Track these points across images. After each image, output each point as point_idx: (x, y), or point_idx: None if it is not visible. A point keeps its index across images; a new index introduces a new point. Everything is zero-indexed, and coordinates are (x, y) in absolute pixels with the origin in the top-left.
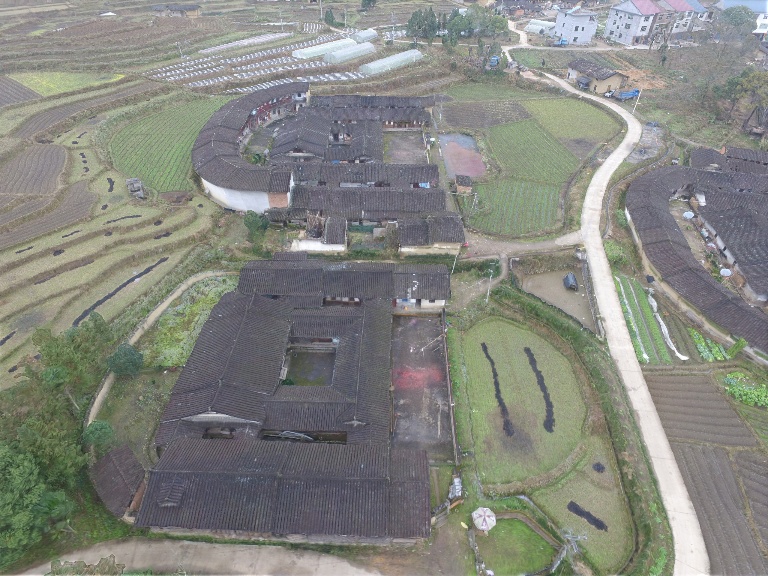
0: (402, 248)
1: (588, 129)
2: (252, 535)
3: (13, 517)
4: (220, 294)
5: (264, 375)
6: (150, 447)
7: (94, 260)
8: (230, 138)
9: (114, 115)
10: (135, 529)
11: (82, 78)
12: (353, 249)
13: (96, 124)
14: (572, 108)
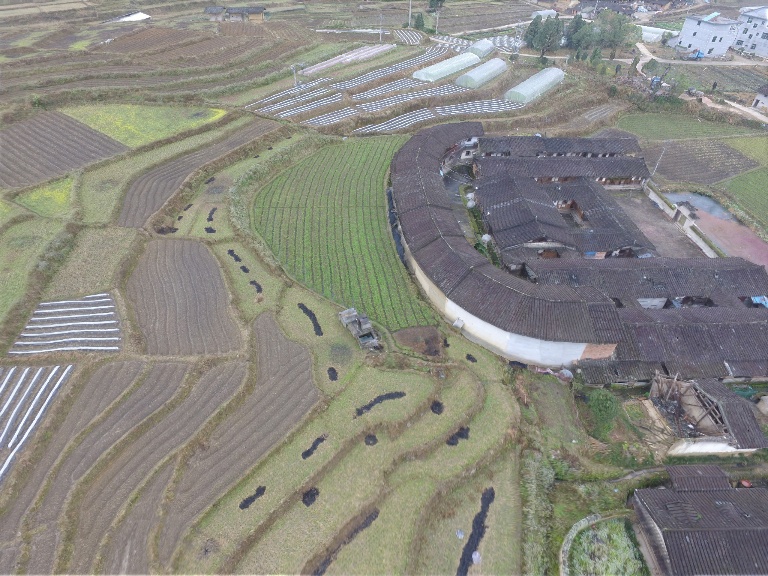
0: None
1: None
2: None
3: None
4: (624, 575)
5: None
6: None
7: (377, 509)
8: (454, 227)
9: (241, 177)
10: None
11: (167, 115)
12: None
13: (222, 193)
14: None
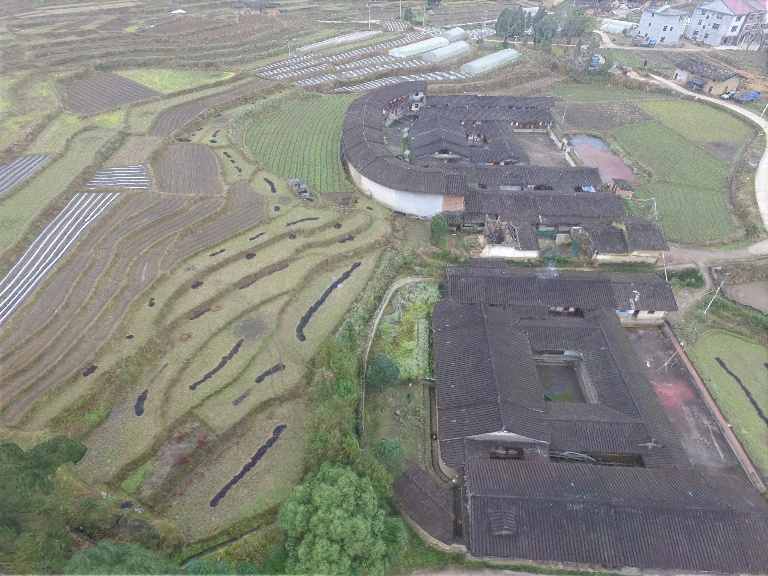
0: (598, 255)
1: (720, 132)
2: (580, 566)
3: (372, 546)
4: (426, 302)
5: (531, 391)
6: (427, 466)
7: (288, 264)
8: (378, 138)
9: (239, 113)
10: (448, 556)
11: (192, 75)
12: (544, 256)
13: (225, 122)
14: (692, 110)
